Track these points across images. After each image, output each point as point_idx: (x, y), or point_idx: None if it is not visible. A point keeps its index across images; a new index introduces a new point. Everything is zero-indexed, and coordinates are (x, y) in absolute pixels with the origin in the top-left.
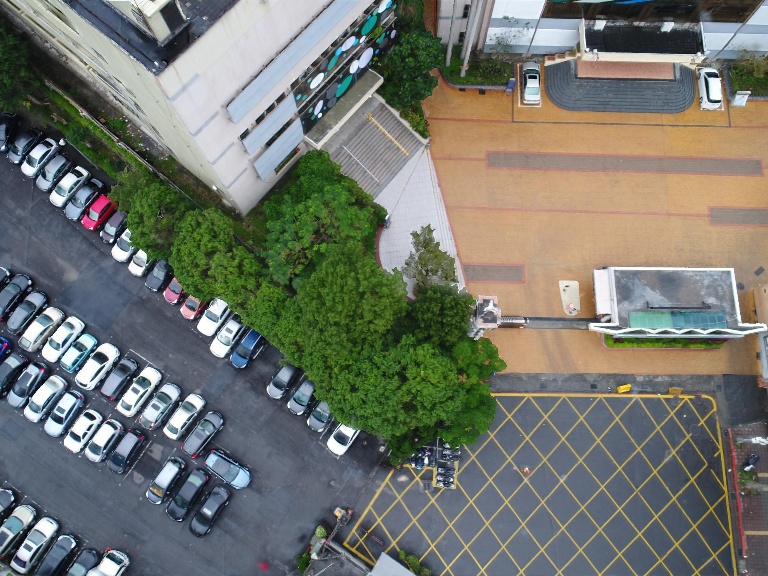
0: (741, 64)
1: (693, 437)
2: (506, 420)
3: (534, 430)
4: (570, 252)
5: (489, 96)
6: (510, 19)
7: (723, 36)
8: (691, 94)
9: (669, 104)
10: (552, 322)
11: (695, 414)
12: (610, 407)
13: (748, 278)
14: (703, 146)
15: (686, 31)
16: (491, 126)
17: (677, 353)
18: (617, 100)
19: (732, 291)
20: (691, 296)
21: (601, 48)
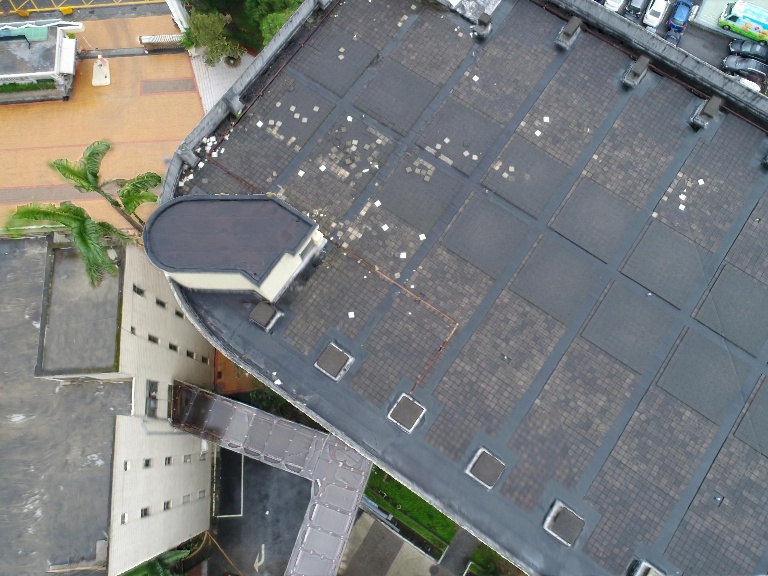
0: None
1: None
2: None
3: None
4: (96, 110)
5: None
6: None
7: None
8: None
9: None
10: (120, 54)
11: None
12: None
13: None
14: None
15: None
16: None
17: None
18: None
19: None
20: None
21: None
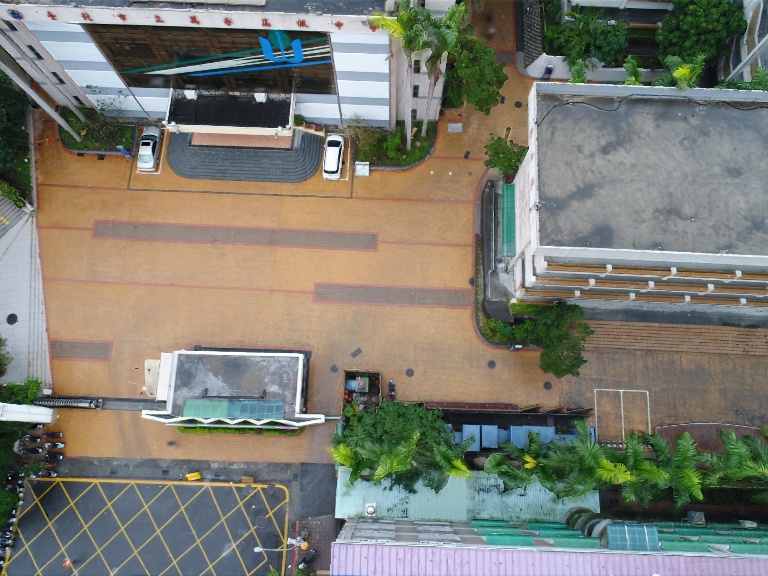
0: (375, 131)
1: (257, 530)
2: (67, 507)
3: (94, 519)
4: (163, 329)
5: (108, 162)
6: (93, 88)
7: (329, 106)
8: (314, 163)
9: (288, 173)
10: (132, 403)
11: (264, 505)
12: (177, 495)
13: (343, 360)
14: (320, 218)
15: (283, 102)
16: (104, 194)
17: (257, 439)
18: (234, 168)
19: (296, 379)
20: (253, 383)
21: (191, 119)
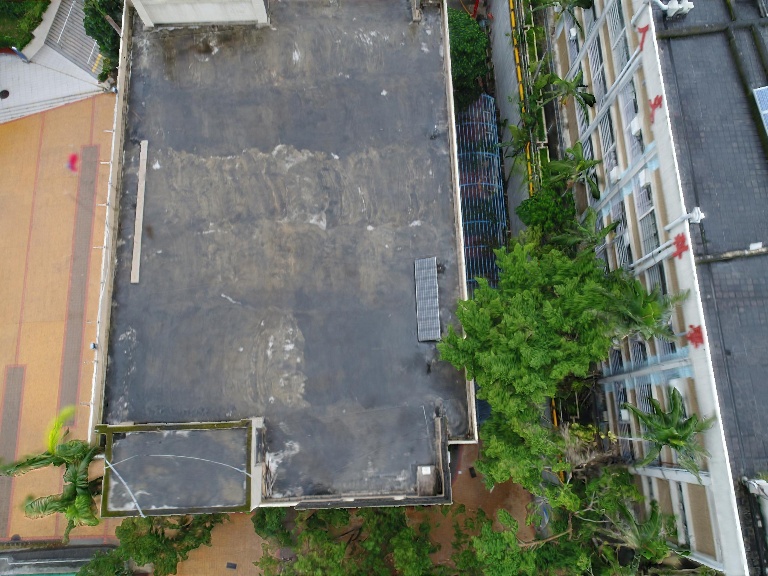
0: None
1: None
2: None
3: None
4: None
5: None
6: None
7: None
8: None
9: None
10: None
11: None
12: None
13: None
14: None
15: None
16: None
17: None
18: None
19: None
20: None
21: None
